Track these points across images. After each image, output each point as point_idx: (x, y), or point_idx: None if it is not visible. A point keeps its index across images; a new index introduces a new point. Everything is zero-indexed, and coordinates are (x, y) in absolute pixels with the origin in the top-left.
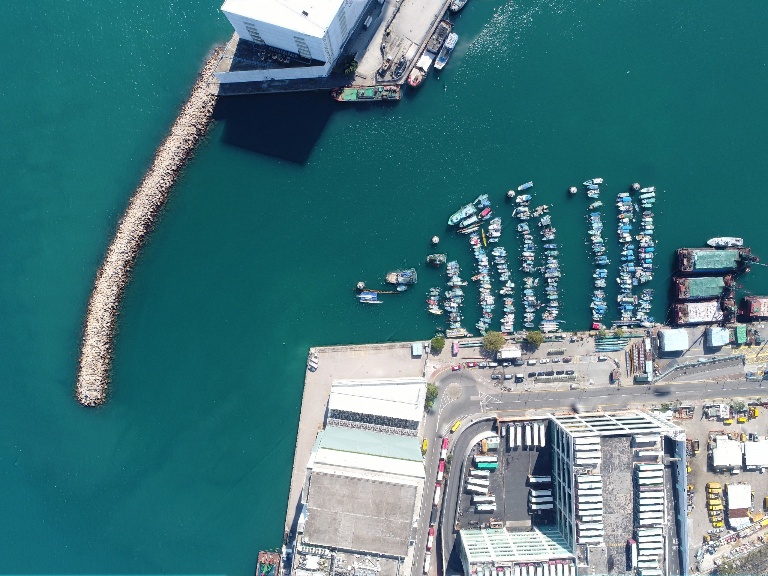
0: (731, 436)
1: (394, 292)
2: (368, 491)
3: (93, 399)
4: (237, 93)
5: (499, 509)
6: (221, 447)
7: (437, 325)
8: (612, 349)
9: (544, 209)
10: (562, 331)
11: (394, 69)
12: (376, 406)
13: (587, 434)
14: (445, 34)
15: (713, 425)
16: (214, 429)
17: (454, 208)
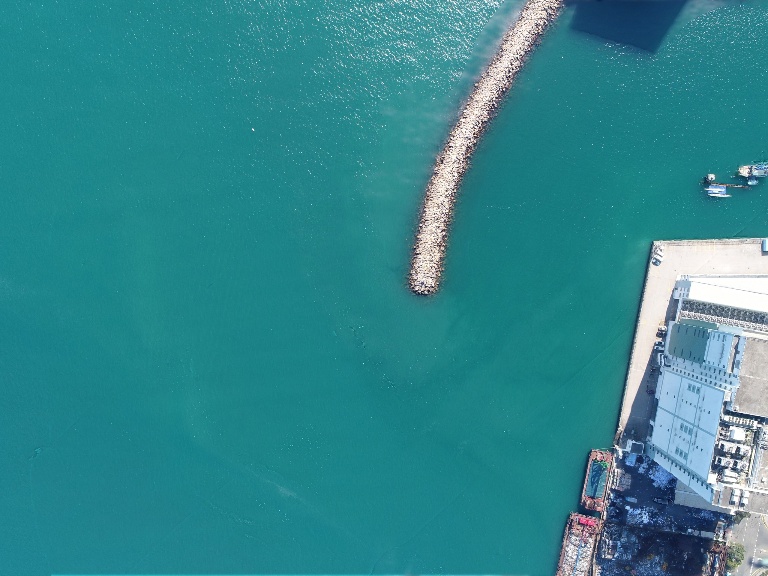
0: None
1: (744, 186)
2: None
3: (428, 286)
4: None
5: None
6: (553, 341)
7: None
8: None
9: None
10: None
11: None
12: (739, 297)
13: None
14: None
15: None
16: (547, 322)
17: None
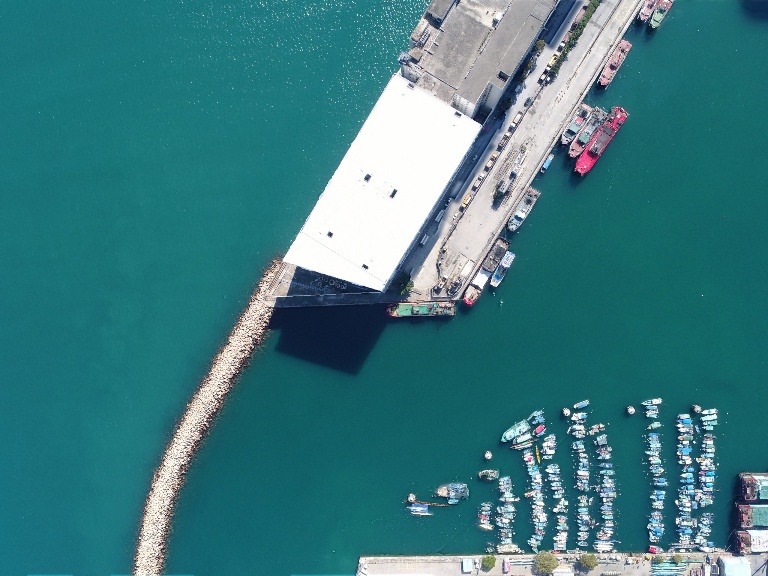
0: None
1: (445, 505)
2: None
3: None
4: (293, 306)
5: None
6: None
7: (488, 540)
8: (669, 574)
9: (600, 428)
10: (617, 551)
11: (449, 285)
12: None
13: None
14: (502, 254)
15: None
16: None
17: (507, 423)
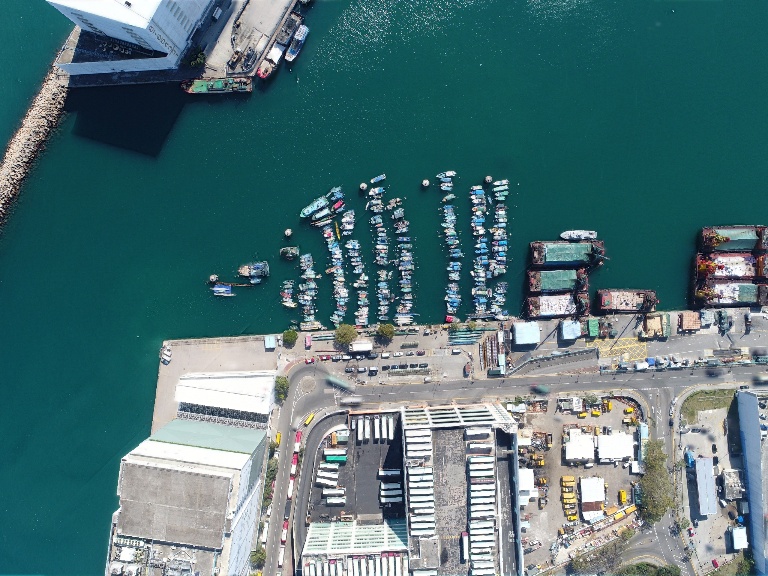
0: (585, 429)
1: (248, 285)
2: (181, 483)
3: None
4: (87, 85)
5: (350, 502)
6: (76, 440)
7: (291, 318)
8: (465, 342)
9: (397, 202)
10: (416, 324)
11: (245, 61)
12: (222, 399)
13: (419, 426)
14: (294, 26)
15: (567, 418)
16: (69, 422)
17: (307, 201)
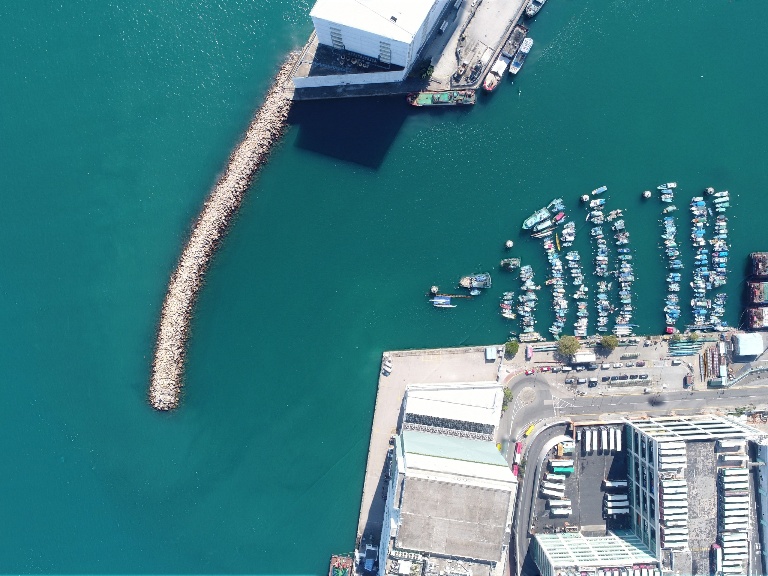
0: None
1: (467, 296)
2: (462, 496)
3: (167, 403)
4: (312, 98)
5: (574, 513)
6: (293, 451)
7: (510, 329)
8: (686, 353)
9: (618, 213)
10: (635, 335)
11: (469, 74)
12: (453, 410)
13: (672, 439)
14: (521, 39)
15: None
16: (287, 433)
17: (528, 212)
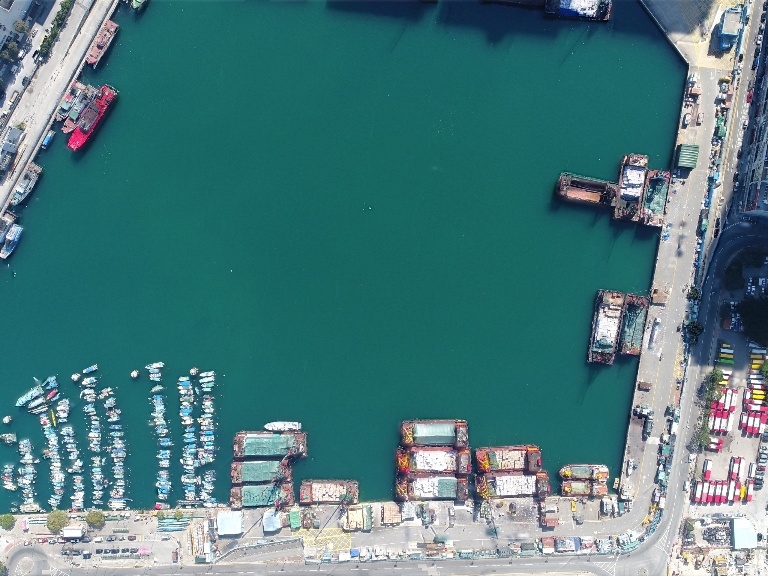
0: None
1: None
2: None
3: None
4: None
5: None
6: None
7: (12, 500)
8: (174, 529)
9: (109, 391)
10: (129, 509)
11: None
12: None
13: None
14: (4, 227)
15: None
16: None
17: (25, 389)
